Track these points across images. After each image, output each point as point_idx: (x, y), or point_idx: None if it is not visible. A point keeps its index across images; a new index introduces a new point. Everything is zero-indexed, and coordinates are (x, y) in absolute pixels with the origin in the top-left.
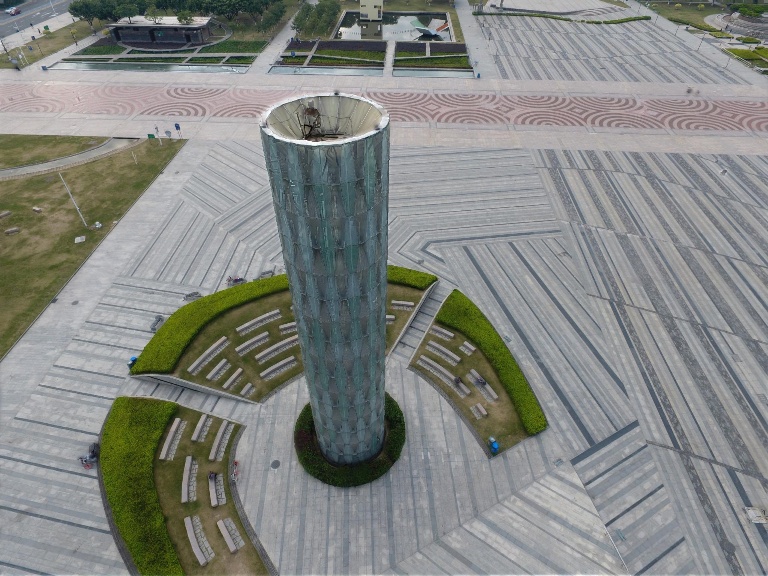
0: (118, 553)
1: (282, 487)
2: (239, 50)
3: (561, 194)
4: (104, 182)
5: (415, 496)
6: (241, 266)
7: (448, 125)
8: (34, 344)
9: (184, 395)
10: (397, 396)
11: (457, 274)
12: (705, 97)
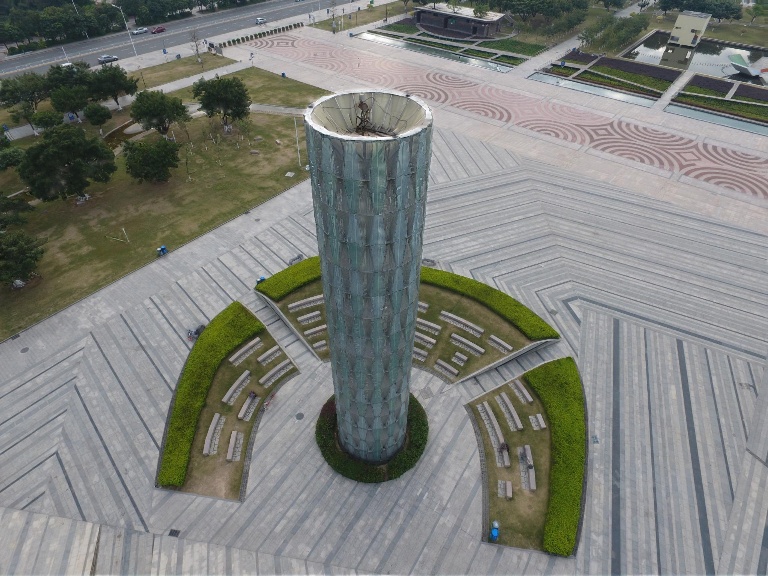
0: (168, 408)
1: (292, 437)
2: (515, 50)
3: None
4: None
5: (387, 521)
6: None
7: (696, 182)
8: (217, 238)
9: (277, 324)
10: (435, 424)
11: (586, 343)
12: None
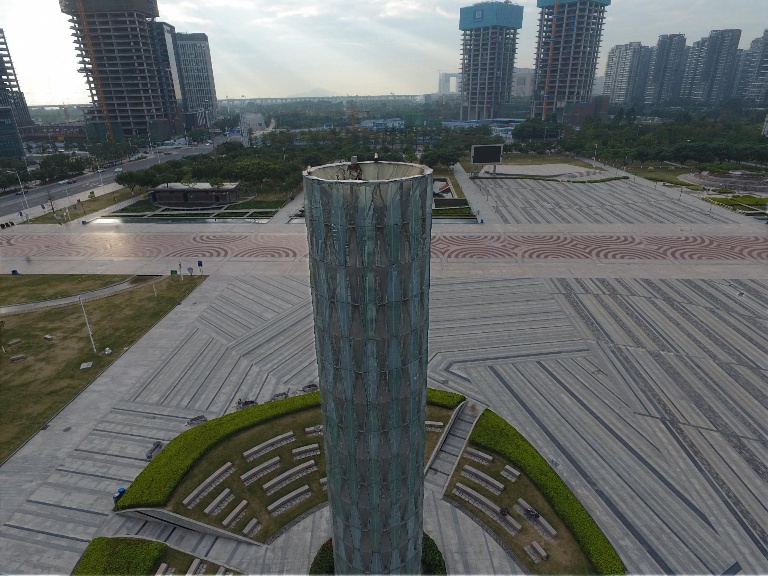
0: None
1: None
2: (262, 207)
3: (581, 316)
4: (121, 312)
5: None
6: (252, 389)
7: (458, 260)
8: (11, 475)
9: (175, 535)
10: (433, 533)
11: (486, 394)
12: (699, 234)
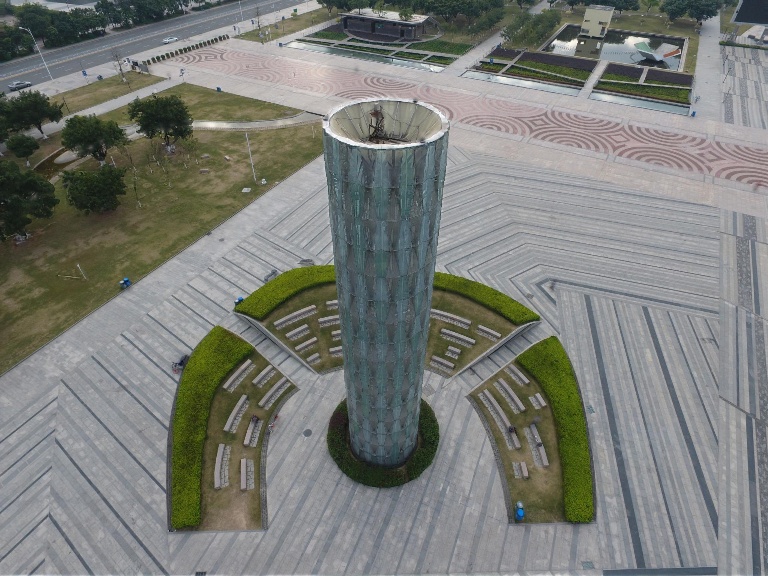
0: (166, 447)
1: (304, 455)
2: (443, 50)
3: (740, 271)
4: (283, 147)
5: (416, 522)
6: None
7: (629, 161)
8: (182, 263)
9: (264, 343)
10: (443, 419)
11: (564, 321)
12: None
